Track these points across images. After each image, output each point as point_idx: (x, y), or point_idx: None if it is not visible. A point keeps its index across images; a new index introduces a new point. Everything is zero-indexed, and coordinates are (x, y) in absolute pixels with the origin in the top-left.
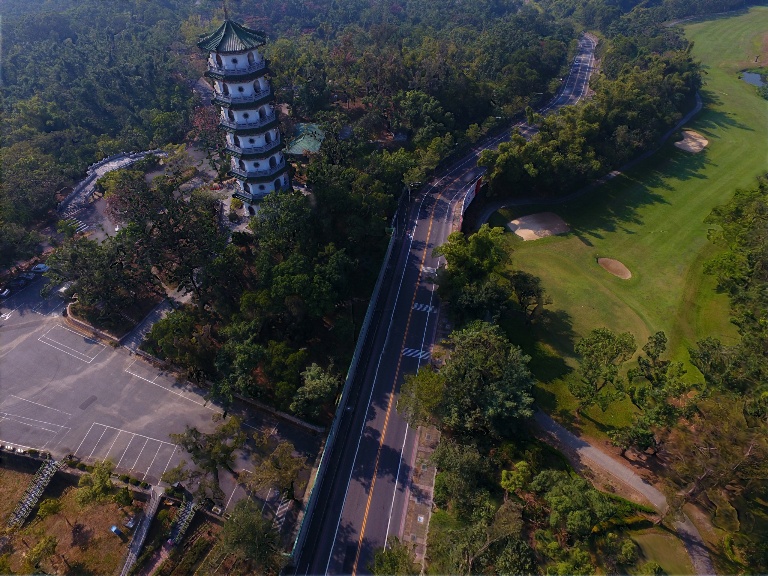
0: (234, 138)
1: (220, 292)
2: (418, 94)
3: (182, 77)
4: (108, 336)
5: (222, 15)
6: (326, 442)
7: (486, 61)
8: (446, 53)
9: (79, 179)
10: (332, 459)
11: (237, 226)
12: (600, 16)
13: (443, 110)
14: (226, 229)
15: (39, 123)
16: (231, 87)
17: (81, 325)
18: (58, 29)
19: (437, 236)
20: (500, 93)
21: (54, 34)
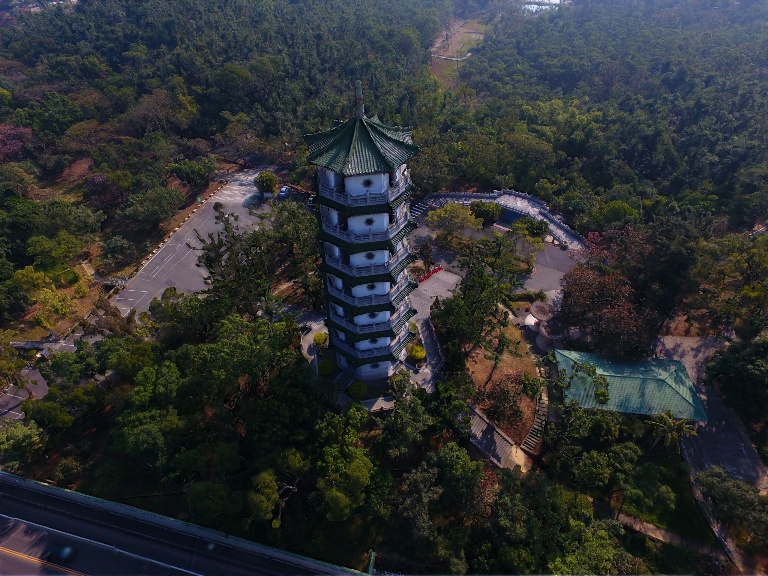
0: None
1: None
2: None
3: None
4: None
5: None
6: (1, 471)
7: None
8: None
9: None
10: (6, 486)
11: None
12: None
13: None
14: None
15: None
16: None
17: None
18: None
19: None
20: None
21: None
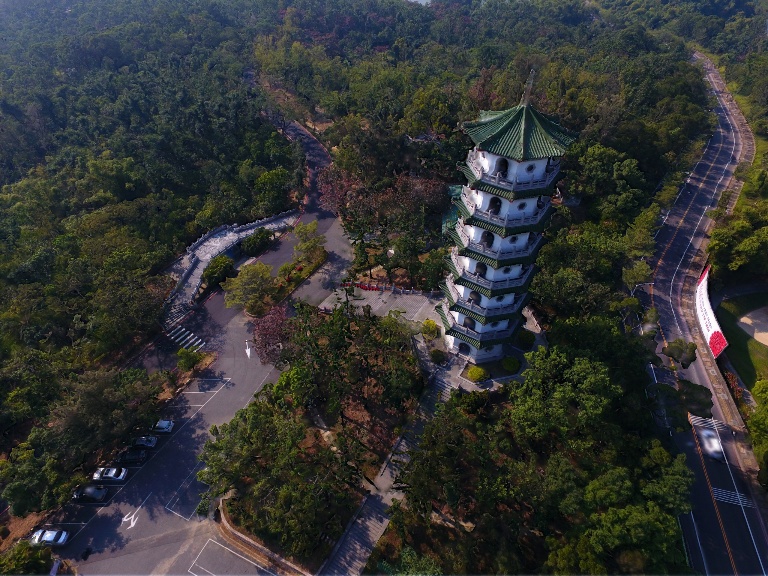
0: (477, 265)
1: (496, 529)
2: (605, 150)
3: (262, 112)
4: (296, 569)
5: (287, 32)
6: None
7: (631, 93)
8: None
9: (171, 261)
10: None
11: (447, 372)
12: (703, 28)
13: (639, 171)
14: (434, 378)
15: (113, 184)
16: (509, 204)
17: (247, 542)
18: (107, 53)
19: None
20: None
21: (108, 61)
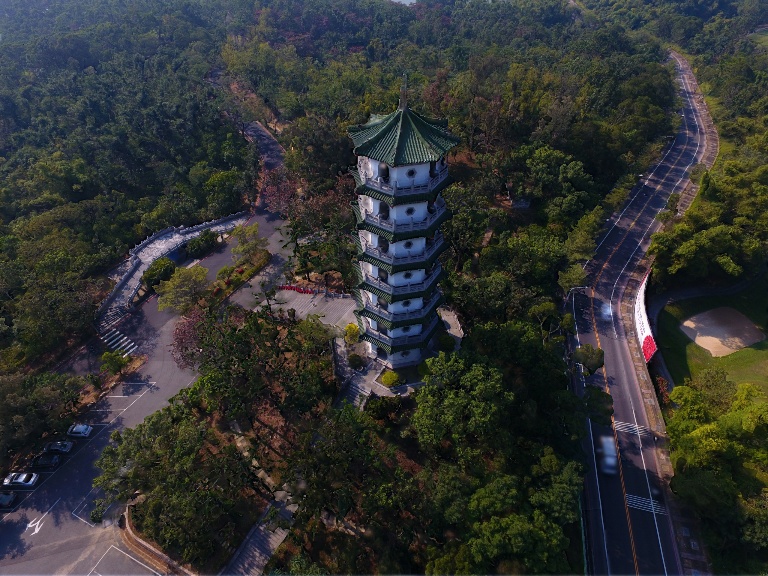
0: (379, 270)
1: (381, 538)
2: (551, 152)
3: (226, 113)
4: None
5: (261, 33)
6: None
7: (594, 94)
8: (540, 83)
9: (116, 263)
10: None
11: (363, 377)
12: (681, 28)
13: (585, 174)
14: (348, 383)
15: (63, 185)
16: (396, 209)
17: (148, 549)
18: (76, 53)
19: (614, 363)
20: (628, 139)
21: (73, 62)
